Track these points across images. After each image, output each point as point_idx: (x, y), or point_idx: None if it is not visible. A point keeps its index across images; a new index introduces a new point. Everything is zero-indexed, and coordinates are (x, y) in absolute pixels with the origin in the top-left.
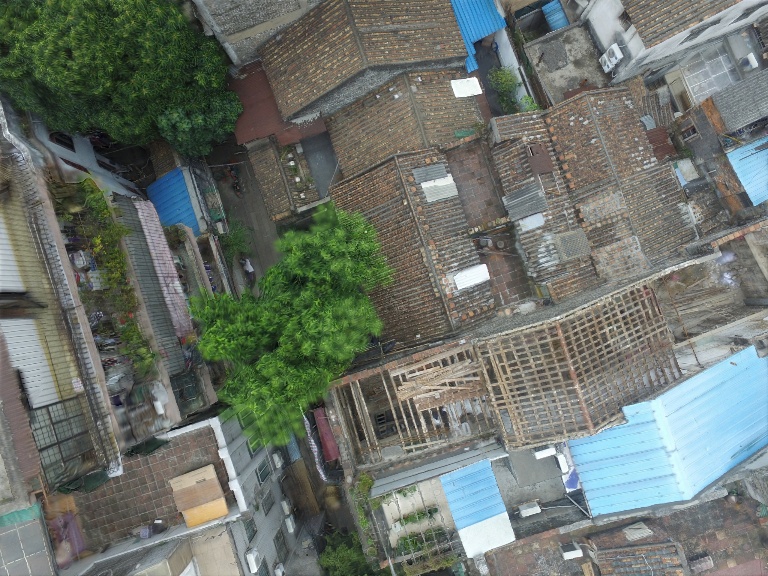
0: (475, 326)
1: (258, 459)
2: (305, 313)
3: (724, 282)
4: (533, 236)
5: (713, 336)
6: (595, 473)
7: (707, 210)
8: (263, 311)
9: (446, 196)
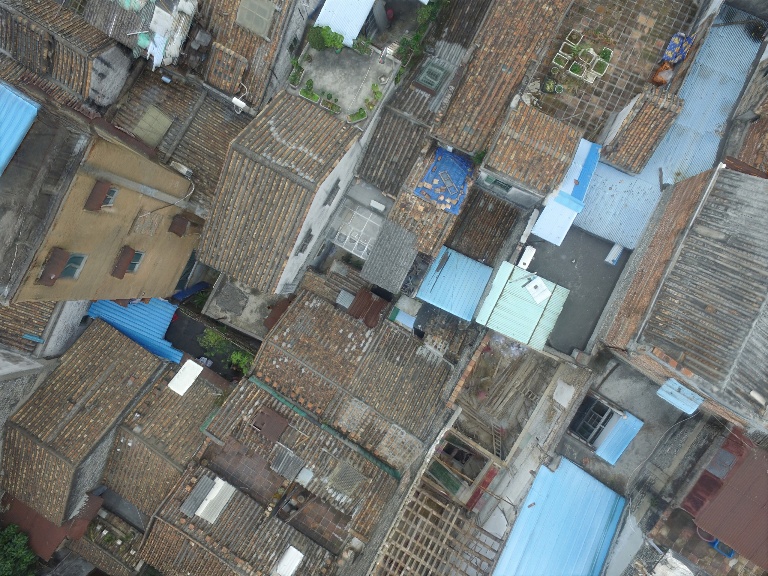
0: None
1: None
2: None
3: (518, 351)
4: (315, 484)
5: (528, 433)
6: None
7: (446, 331)
8: None
9: (226, 501)
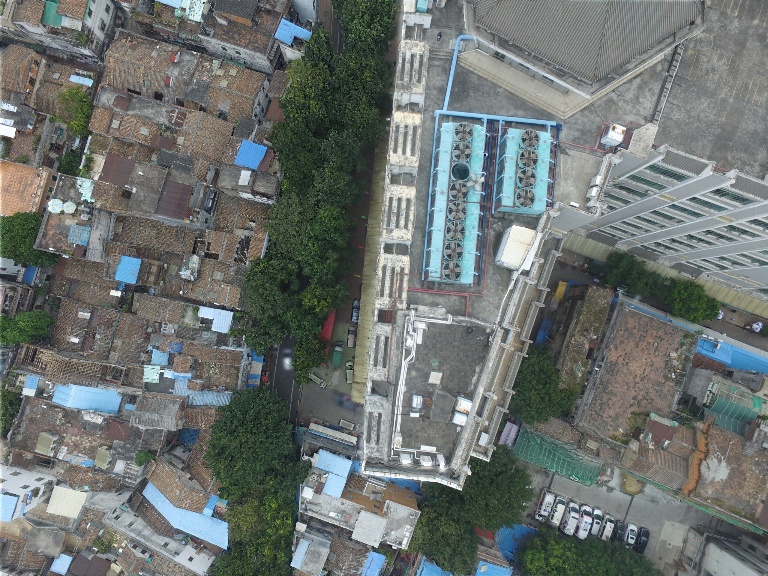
0: (69, 351)
1: (2, 350)
2: (12, 329)
3: None
4: None
5: None
6: (57, 393)
7: None
8: (8, 323)
9: (85, 318)
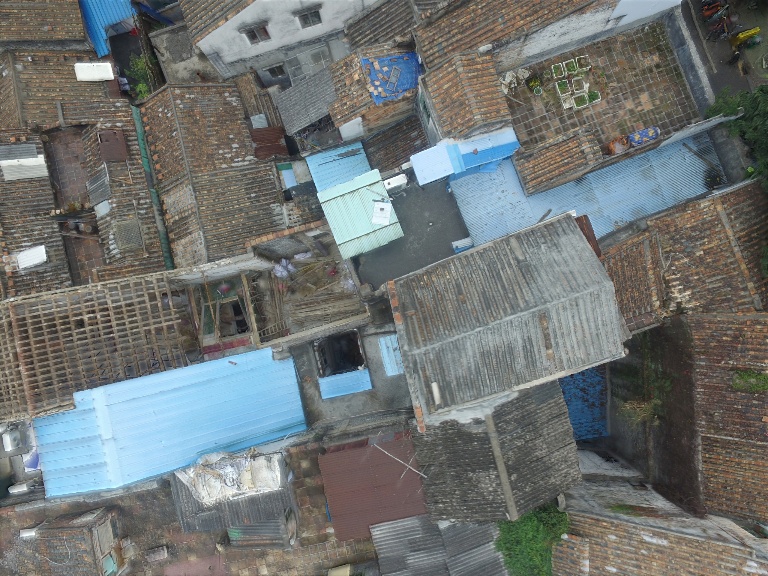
0: None
1: None
2: None
3: (353, 288)
4: (105, 223)
5: None
6: (50, 455)
7: (309, 213)
8: None
9: (31, 176)
